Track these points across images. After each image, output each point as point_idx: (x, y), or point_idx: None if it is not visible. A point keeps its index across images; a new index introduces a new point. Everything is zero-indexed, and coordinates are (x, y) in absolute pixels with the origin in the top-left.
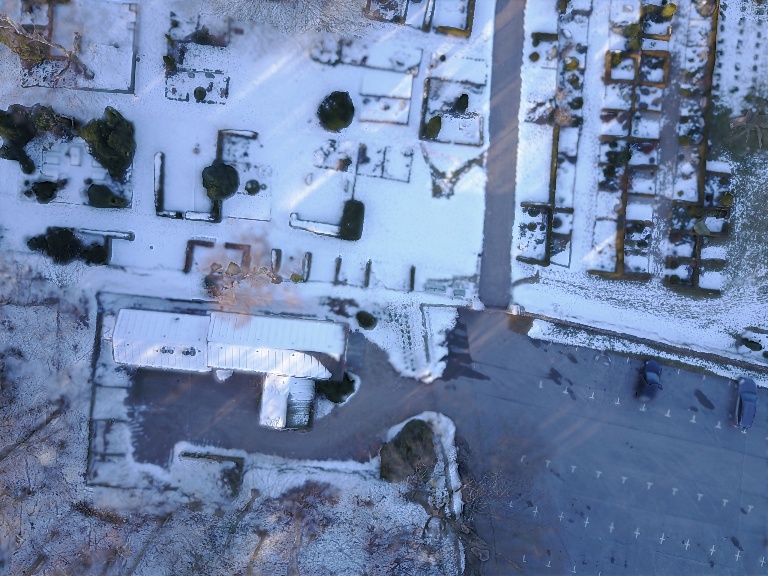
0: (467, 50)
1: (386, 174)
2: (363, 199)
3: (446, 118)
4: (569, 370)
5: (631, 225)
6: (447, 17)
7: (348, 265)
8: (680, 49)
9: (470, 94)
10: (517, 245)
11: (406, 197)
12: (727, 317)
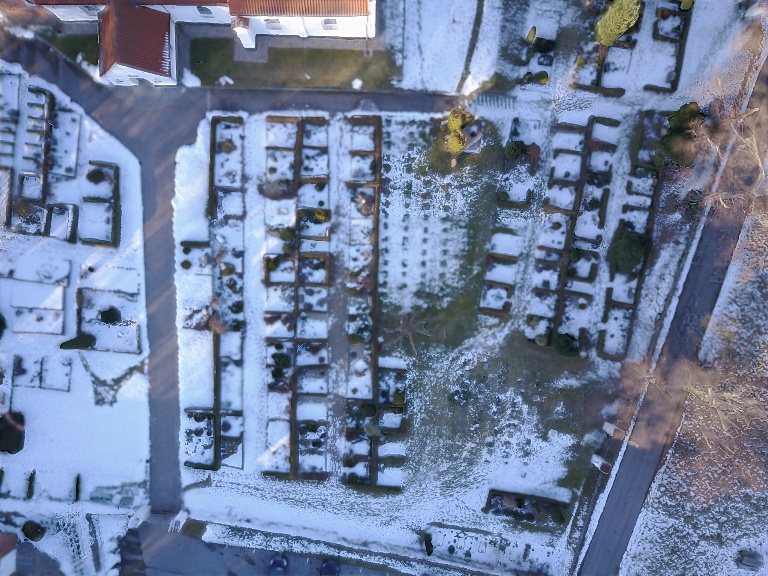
0: (117, 259)
1: (45, 384)
2: (23, 410)
3: (104, 326)
4: (247, 572)
5: (305, 425)
6: (92, 228)
7: (12, 476)
8: (343, 248)
9: (125, 302)
10: (185, 450)
11: (68, 406)
12: (409, 513)
